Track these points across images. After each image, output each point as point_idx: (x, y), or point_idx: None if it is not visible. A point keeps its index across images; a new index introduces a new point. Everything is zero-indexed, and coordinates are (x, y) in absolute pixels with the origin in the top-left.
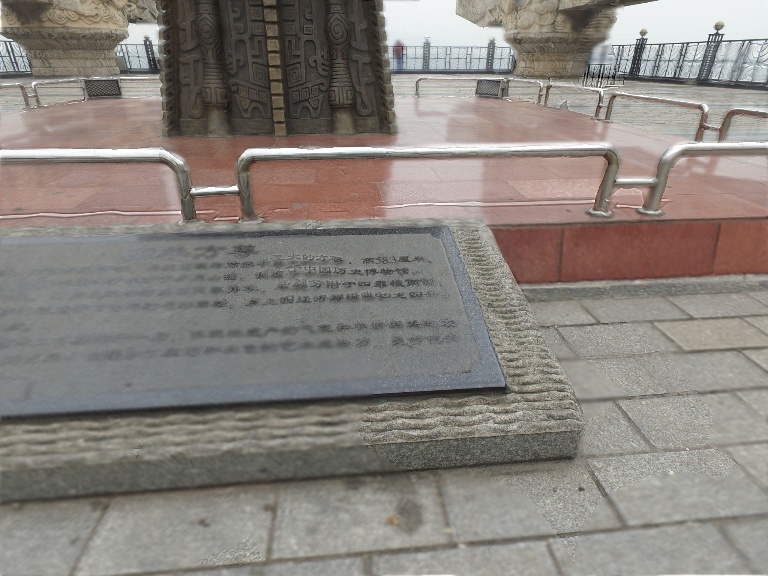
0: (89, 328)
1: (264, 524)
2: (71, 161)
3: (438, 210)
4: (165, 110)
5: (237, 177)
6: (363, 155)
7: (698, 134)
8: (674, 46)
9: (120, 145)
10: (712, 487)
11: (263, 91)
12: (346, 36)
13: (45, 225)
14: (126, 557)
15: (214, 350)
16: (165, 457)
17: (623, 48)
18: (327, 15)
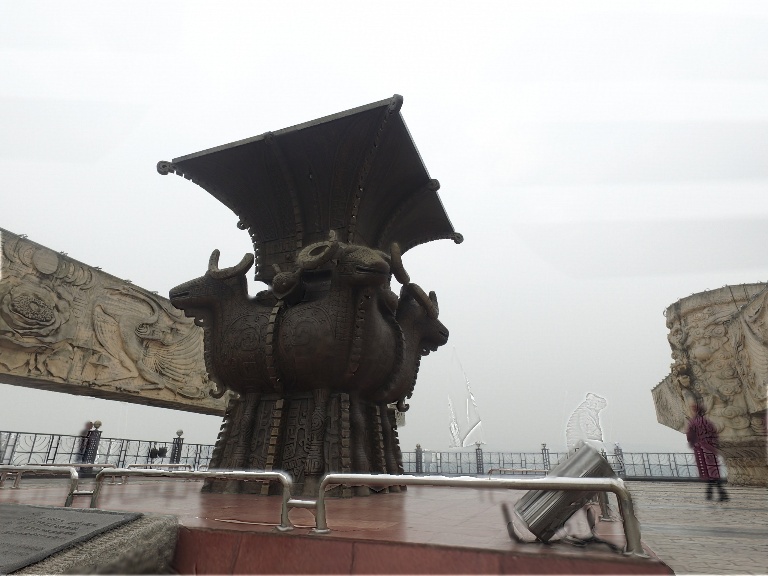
0: None
1: None
2: (39, 472)
3: (196, 520)
4: None
5: (161, 505)
6: (151, 474)
7: None
8: None
9: (162, 493)
10: None
11: None
12: (321, 425)
13: None
14: None
15: None
16: None
17: None
18: None
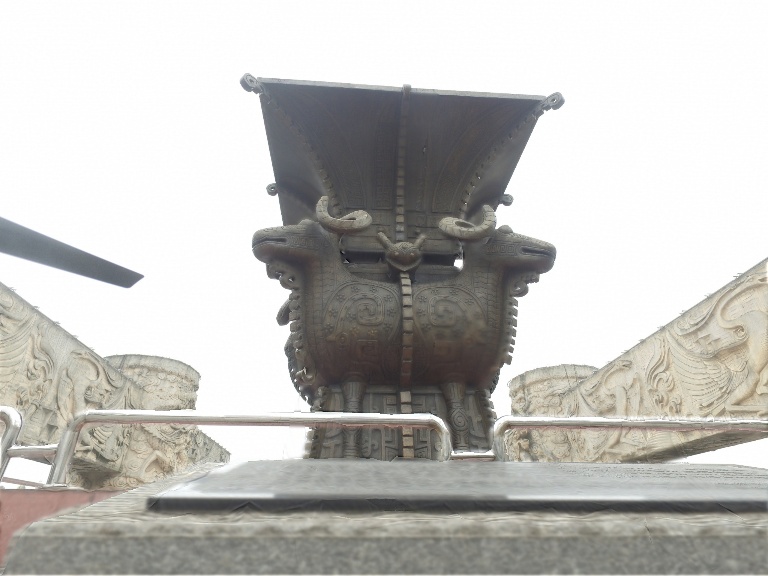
0: None
1: None
2: (354, 422)
3: None
4: None
5: None
6: (602, 423)
7: None
8: None
9: None
10: None
11: None
12: (467, 425)
13: None
14: None
15: None
16: (683, 544)
17: None
18: (450, 410)
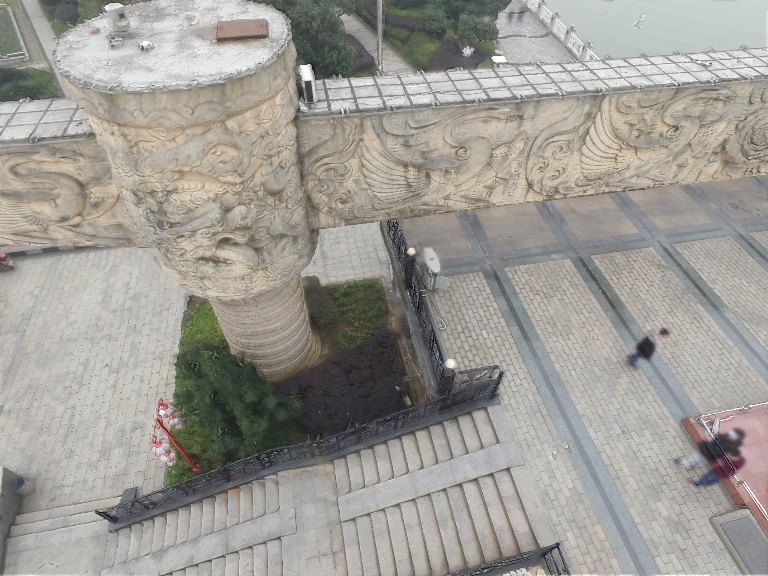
0: (751, 553)
1: None
2: None
3: None
4: None
5: None
6: None
7: None
8: None
9: None
10: None
11: None
12: None
13: (764, 522)
14: (734, 570)
15: (757, 571)
16: None
17: None
18: None
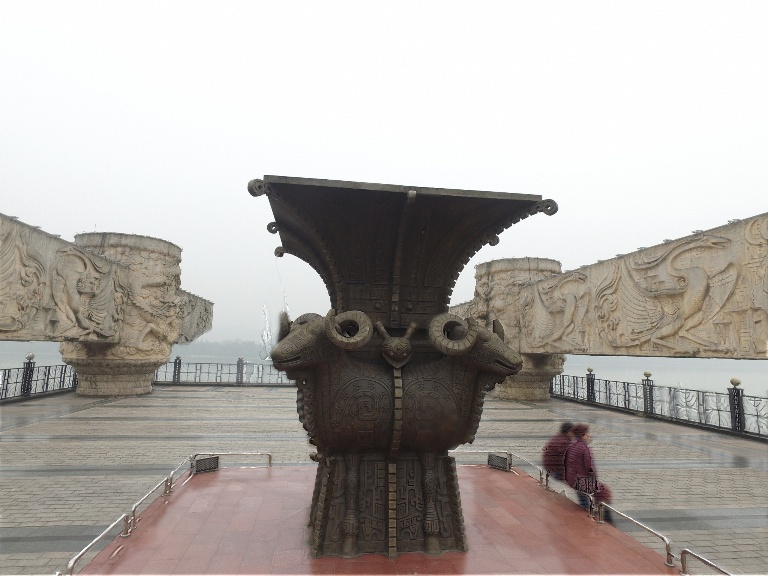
0: None
1: None
2: None
3: None
4: (317, 538)
5: None
6: None
7: (668, 558)
8: (617, 384)
9: (294, 573)
10: None
11: (381, 522)
12: (435, 488)
13: None
14: None
15: None
16: None
17: (577, 379)
18: (424, 476)
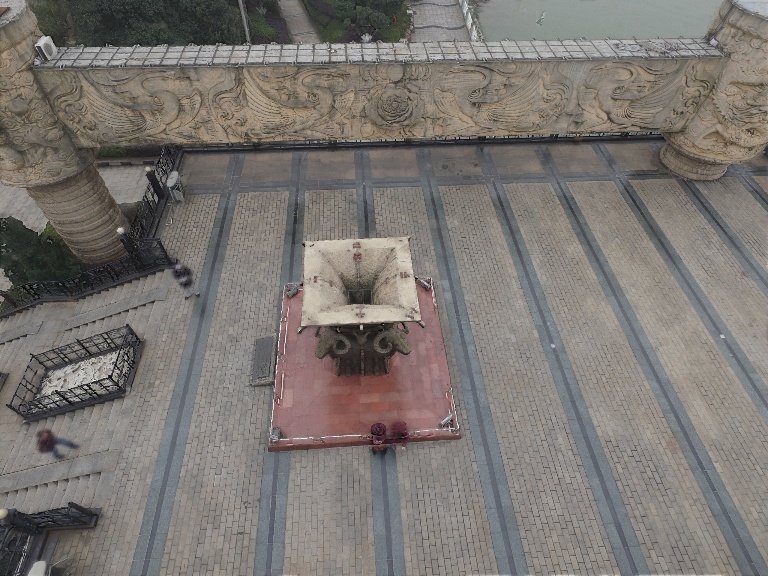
0: None
1: (249, 368)
2: None
3: None
4: None
5: (300, 353)
6: None
7: None
8: None
9: None
10: (246, 392)
11: None
12: None
13: None
14: None
15: None
16: None
17: None
18: None
